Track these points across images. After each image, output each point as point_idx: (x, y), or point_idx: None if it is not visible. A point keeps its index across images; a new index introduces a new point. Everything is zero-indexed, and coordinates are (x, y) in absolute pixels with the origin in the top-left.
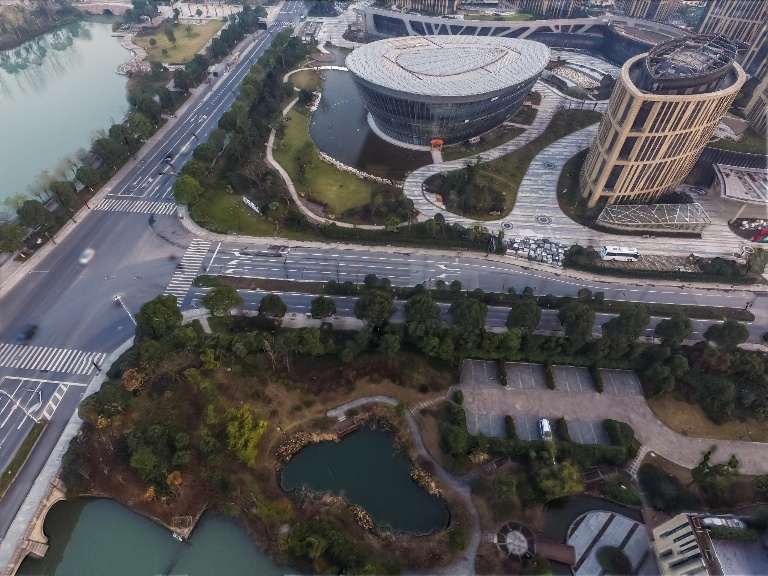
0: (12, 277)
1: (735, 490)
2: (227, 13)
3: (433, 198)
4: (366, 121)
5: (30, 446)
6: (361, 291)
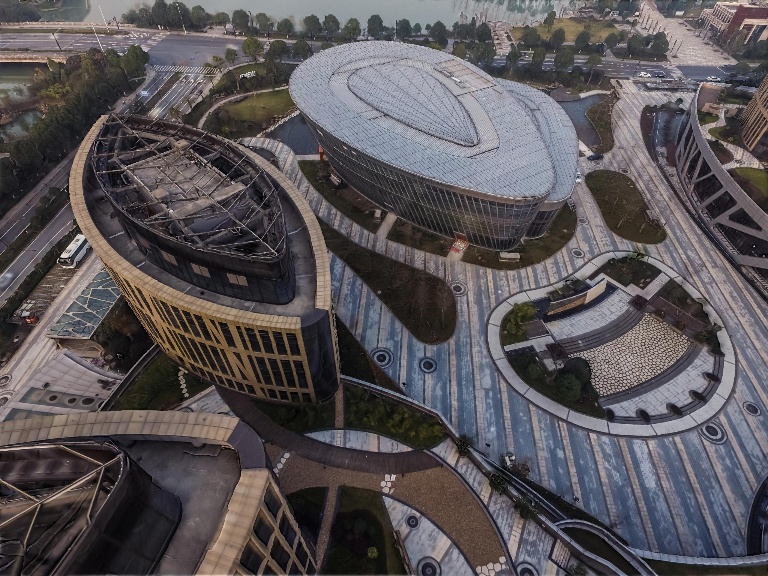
0: (210, 34)
1: None
2: None
3: None
4: None
5: None
6: None
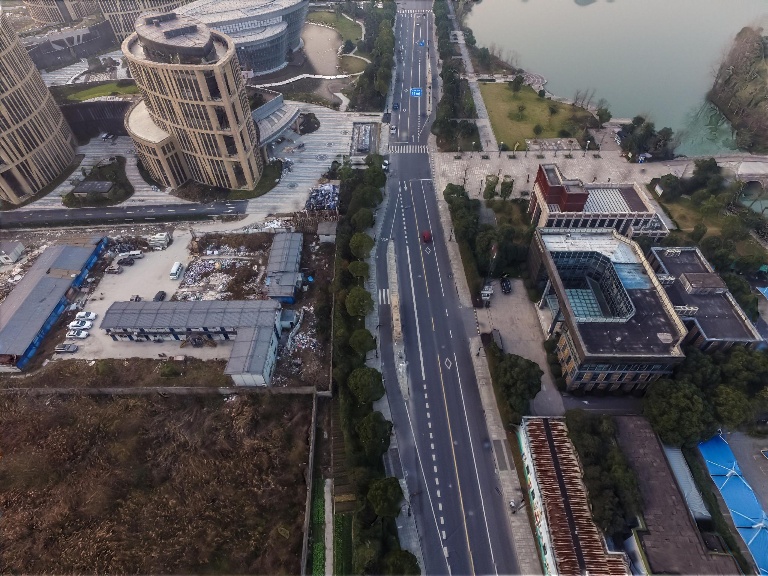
0: None
1: None
2: (520, 168)
3: None
4: (305, 43)
5: None
6: None
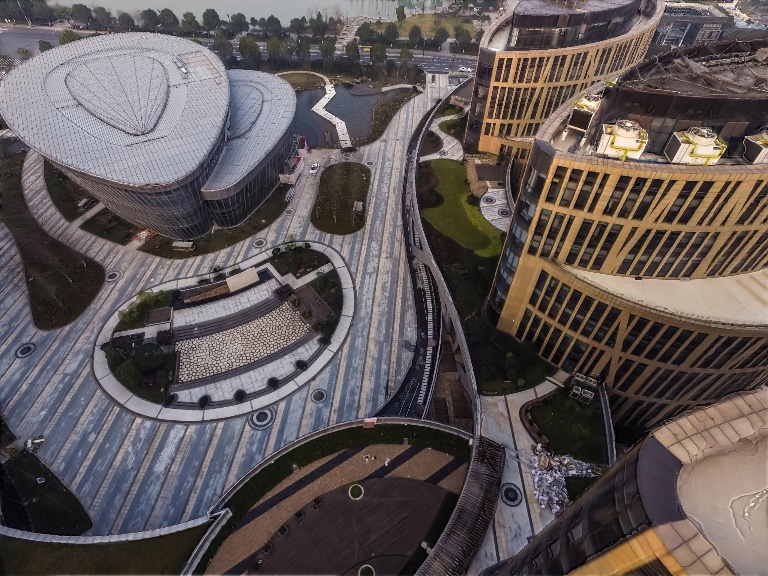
0: None
1: None
2: None
3: None
4: None
5: None
6: None
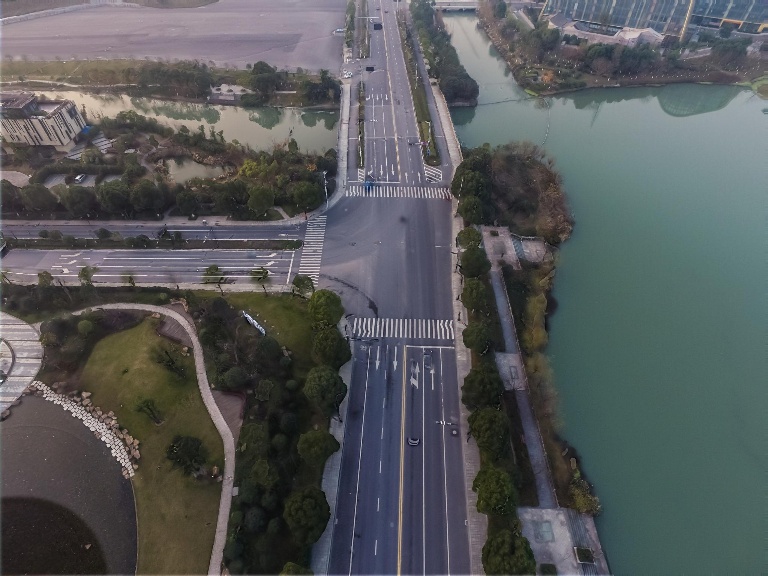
0: None
1: (6, 162)
2: None
3: (3, 360)
4: None
5: (359, 159)
6: (156, 241)
